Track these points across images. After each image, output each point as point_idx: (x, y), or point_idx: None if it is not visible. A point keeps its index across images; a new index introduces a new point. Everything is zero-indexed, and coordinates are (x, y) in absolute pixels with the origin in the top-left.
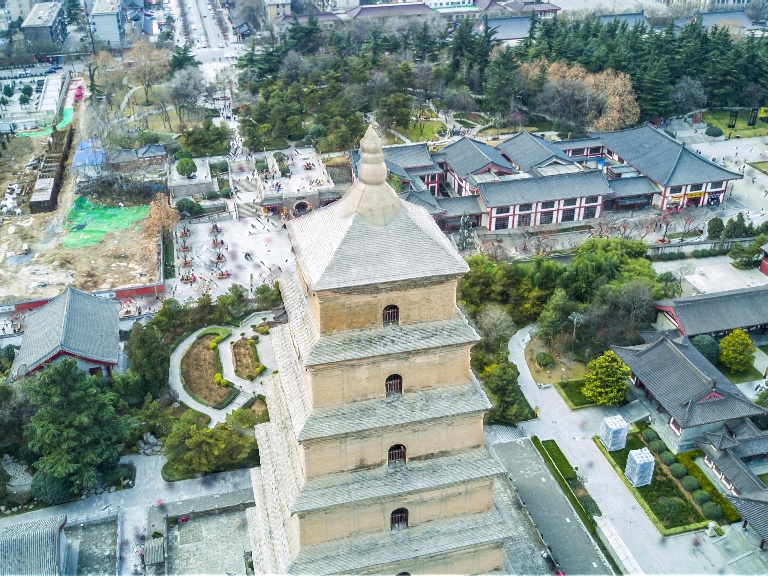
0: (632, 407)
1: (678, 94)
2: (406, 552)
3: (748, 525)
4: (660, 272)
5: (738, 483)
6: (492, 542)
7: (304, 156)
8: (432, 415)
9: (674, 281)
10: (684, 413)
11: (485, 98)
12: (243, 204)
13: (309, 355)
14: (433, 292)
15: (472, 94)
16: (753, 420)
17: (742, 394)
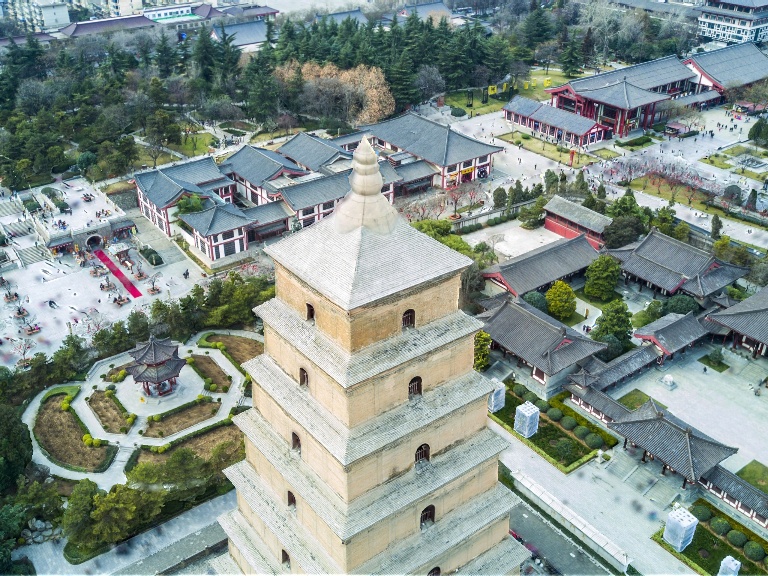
0: (495, 369)
1: (421, 82)
2: (440, 547)
3: (626, 445)
4: (470, 244)
5: (609, 411)
6: (503, 514)
7: (77, 188)
8: (452, 408)
9: (489, 250)
10: (547, 363)
11: (249, 105)
12: (24, 250)
13: (347, 376)
14: (442, 290)
15: (231, 102)
16: (596, 356)
17: (583, 336)
